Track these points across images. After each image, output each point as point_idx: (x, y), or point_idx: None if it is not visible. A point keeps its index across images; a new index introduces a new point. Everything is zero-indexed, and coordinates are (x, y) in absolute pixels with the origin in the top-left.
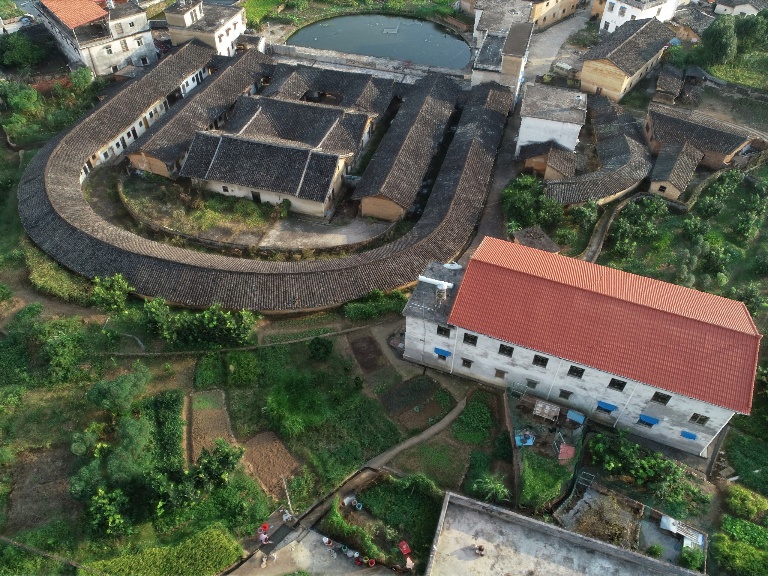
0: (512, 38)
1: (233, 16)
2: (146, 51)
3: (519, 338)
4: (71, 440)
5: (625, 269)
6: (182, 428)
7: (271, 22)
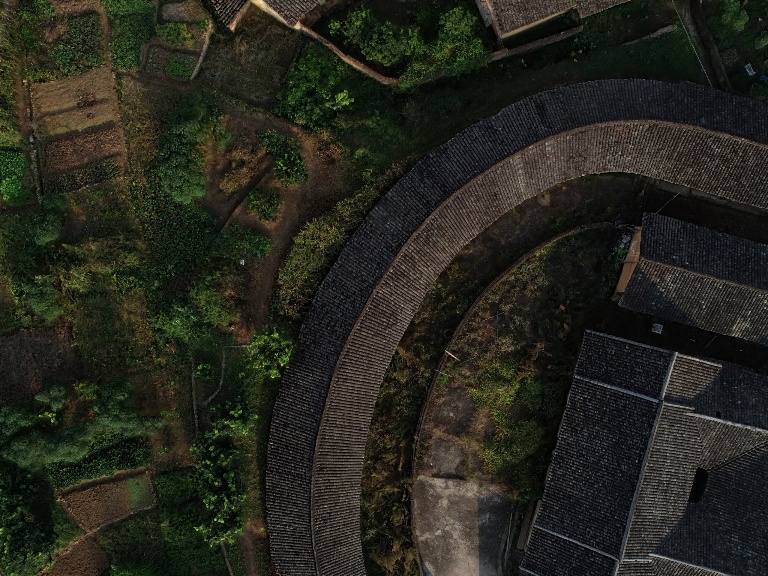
0: None
1: None
2: None
3: None
4: (51, 387)
5: None
6: None
7: None
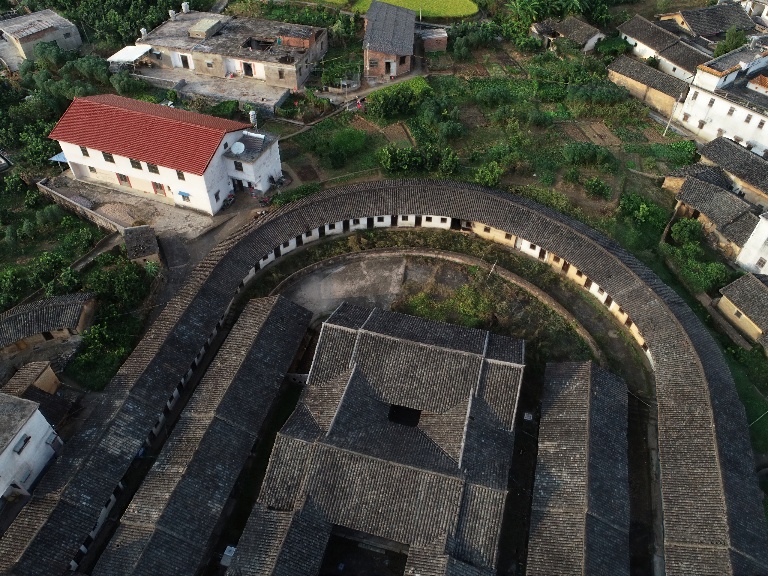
0: None
1: None
2: None
3: (212, 117)
4: None
5: (67, 254)
6: (411, 132)
7: None
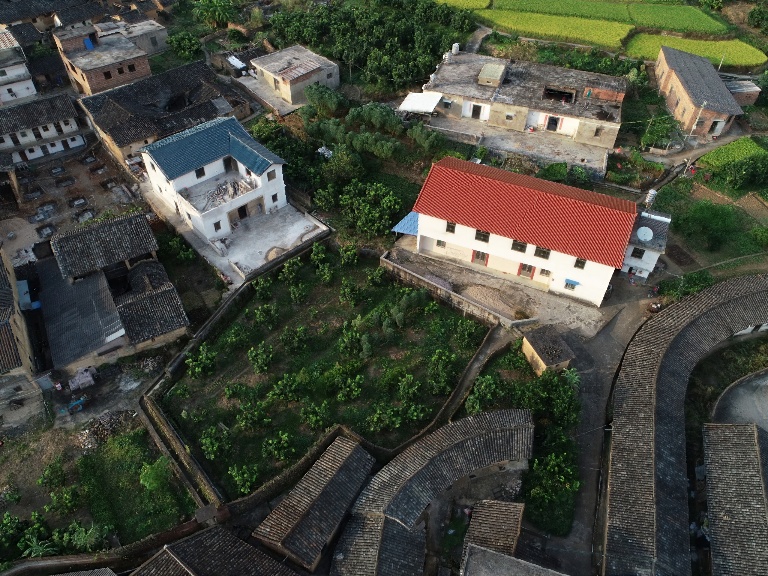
0: None
1: None
2: None
3: None
4: None
5: (445, 348)
6: None
7: None
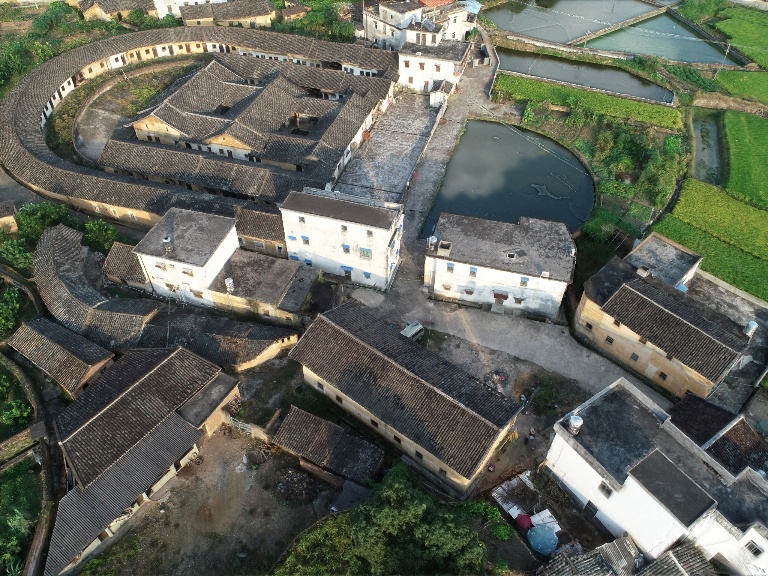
0: (336, 204)
1: (437, 58)
2: (395, 43)
3: None
4: None
5: None
6: None
7: (524, 107)
